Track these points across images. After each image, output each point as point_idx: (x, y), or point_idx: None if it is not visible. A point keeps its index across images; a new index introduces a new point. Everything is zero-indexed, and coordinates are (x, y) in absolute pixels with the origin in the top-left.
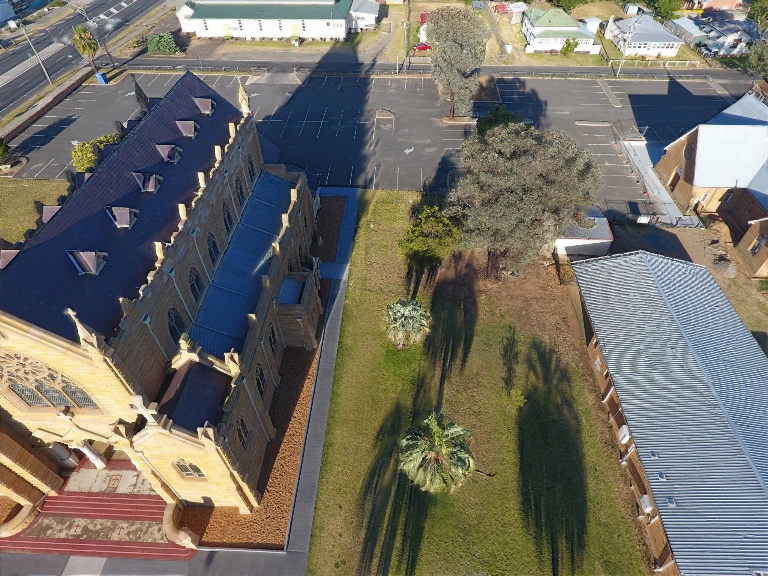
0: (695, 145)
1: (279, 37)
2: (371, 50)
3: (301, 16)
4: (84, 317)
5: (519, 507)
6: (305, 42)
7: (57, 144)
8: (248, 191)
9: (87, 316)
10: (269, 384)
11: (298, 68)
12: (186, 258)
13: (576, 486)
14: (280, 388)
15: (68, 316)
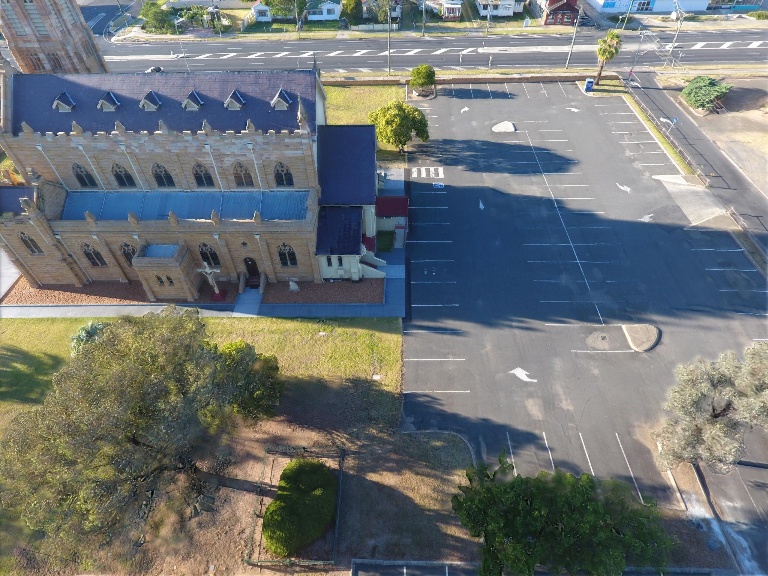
0: None
1: None
2: None
3: None
4: (31, 119)
5: None
6: None
7: (460, 103)
8: (260, 185)
9: (32, 120)
10: (110, 270)
11: (747, 213)
12: (109, 153)
13: None
14: (119, 284)
15: (27, 112)
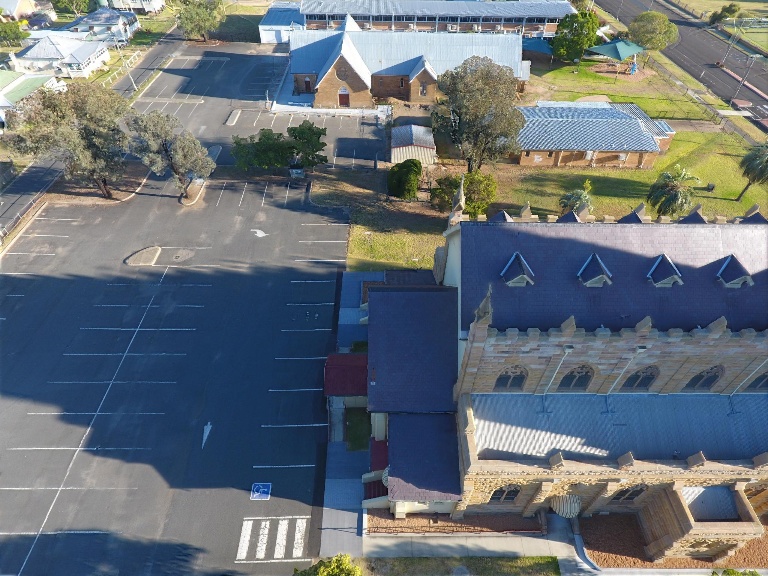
0: (346, 67)
1: None
2: None
3: None
4: None
5: (642, 200)
6: None
7: None
8: None
9: None
10: None
11: None
12: None
13: (618, 181)
14: None
15: None
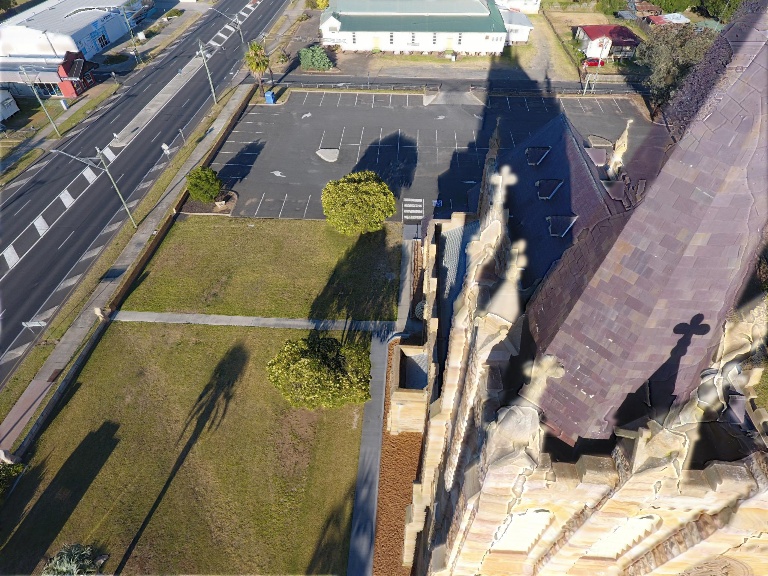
0: None
1: (430, 51)
2: (536, 66)
3: (458, 29)
4: None
5: None
6: (459, 56)
7: (259, 175)
8: None
9: None
10: None
11: (471, 86)
12: None
13: None
14: None
15: None
